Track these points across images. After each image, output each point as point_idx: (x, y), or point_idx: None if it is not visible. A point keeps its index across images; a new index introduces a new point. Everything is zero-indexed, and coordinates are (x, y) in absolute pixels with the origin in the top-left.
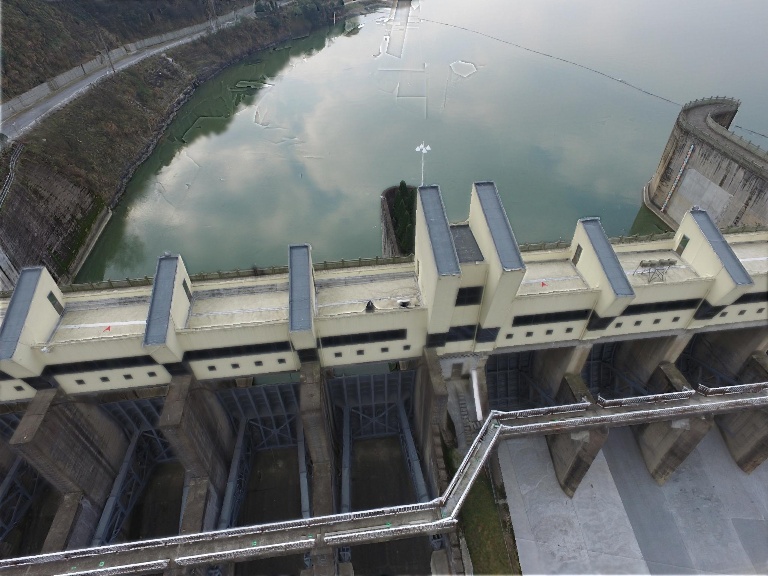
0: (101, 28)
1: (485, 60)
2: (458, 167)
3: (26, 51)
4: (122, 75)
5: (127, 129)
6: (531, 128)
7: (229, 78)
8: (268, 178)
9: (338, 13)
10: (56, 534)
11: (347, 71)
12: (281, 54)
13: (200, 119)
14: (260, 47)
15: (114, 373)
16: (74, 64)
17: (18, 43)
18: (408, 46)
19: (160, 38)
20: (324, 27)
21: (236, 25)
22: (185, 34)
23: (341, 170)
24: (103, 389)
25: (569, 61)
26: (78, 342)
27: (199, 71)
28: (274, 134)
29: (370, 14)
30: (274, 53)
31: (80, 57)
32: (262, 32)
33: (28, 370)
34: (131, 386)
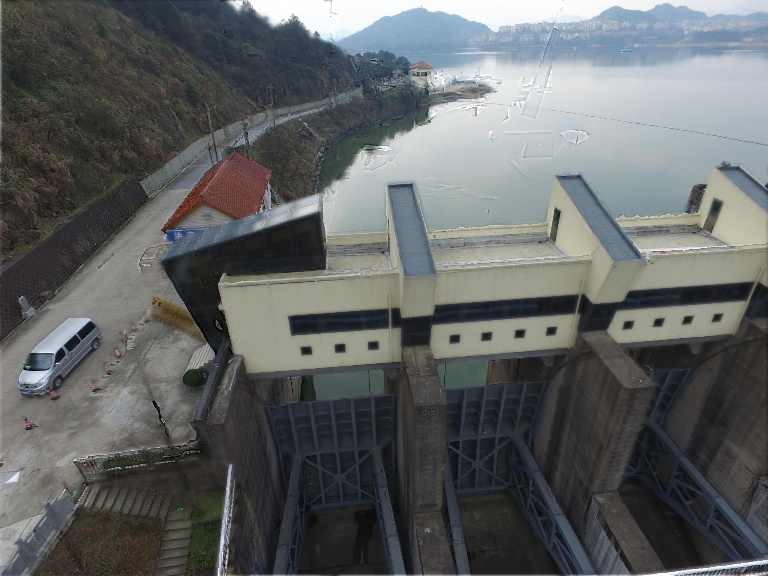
0: (245, 96)
1: (593, 130)
2: (648, 204)
3: (209, 100)
4: (280, 129)
5: (301, 170)
6: (695, 175)
7: (342, 148)
8: (452, 214)
9: (424, 101)
10: (636, 549)
11: (464, 138)
12: (382, 131)
13: (346, 172)
14: (368, 123)
15: (677, 312)
16: (235, 119)
17: (203, 93)
18: (539, 110)
19: (289, 109)
20: (413, 112)
21: (350, 102)
22: (307, 108)
23: (524, 207)
24: (642, 340)
25: (680, 129)
26: (680, 253)
27: (327, 136)
28: (429, 182)
29: (451, 103)
30: (377, 129)
31: (237, 115)
32: (369, 110)
33: (629, 286)
34: (678, 337)
